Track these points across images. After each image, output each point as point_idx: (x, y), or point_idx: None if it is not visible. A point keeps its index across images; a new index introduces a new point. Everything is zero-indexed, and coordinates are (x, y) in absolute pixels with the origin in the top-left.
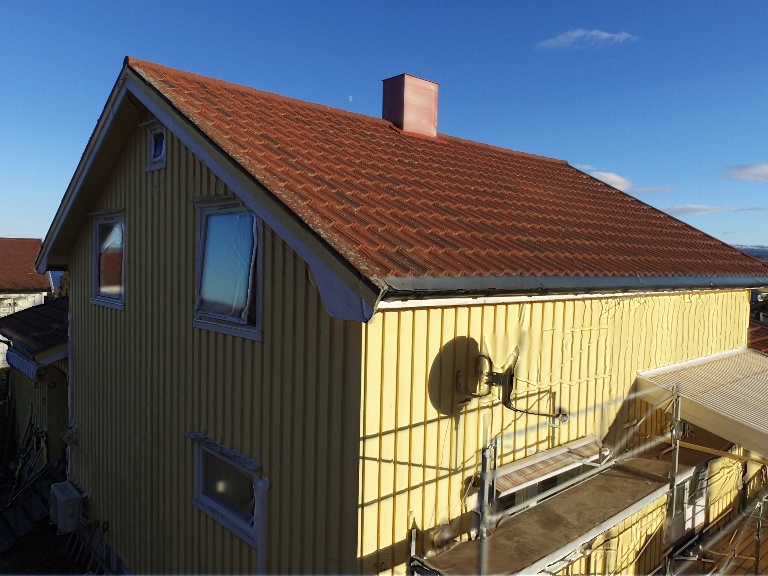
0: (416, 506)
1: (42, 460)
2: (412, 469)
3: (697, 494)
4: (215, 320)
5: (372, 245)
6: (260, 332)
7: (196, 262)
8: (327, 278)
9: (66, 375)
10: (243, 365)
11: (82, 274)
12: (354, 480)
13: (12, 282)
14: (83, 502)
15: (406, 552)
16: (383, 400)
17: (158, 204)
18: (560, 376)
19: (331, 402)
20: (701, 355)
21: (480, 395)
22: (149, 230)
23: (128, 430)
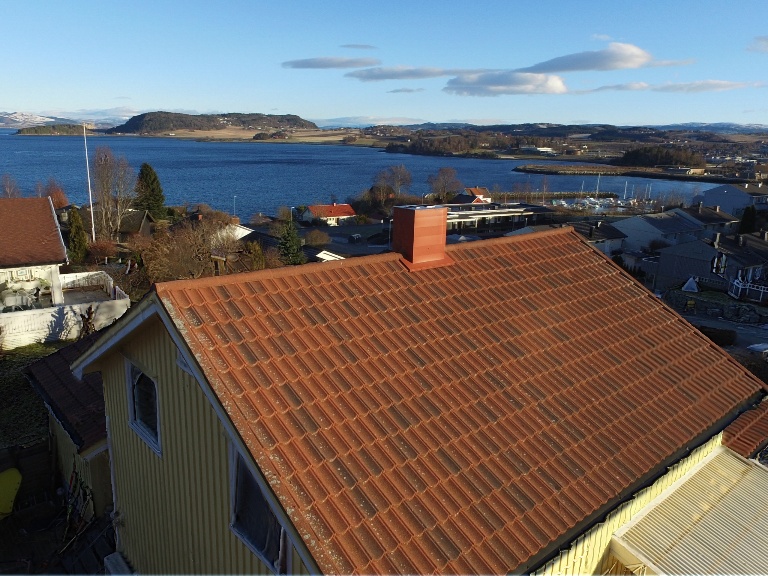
0: None
1: (90, 511)
2: None
3: None
4: None
5: None
6: None
7: (230, 481)
8: None
9: (108, 462)
10: None
11: (117, 392)
12: None
13: (28, 255)
14: None
15: None
16: None
17: (190, 401)
18: None
19: None
20: (675, 480)
21: None
22: (183, 415)
23: (172, 555)
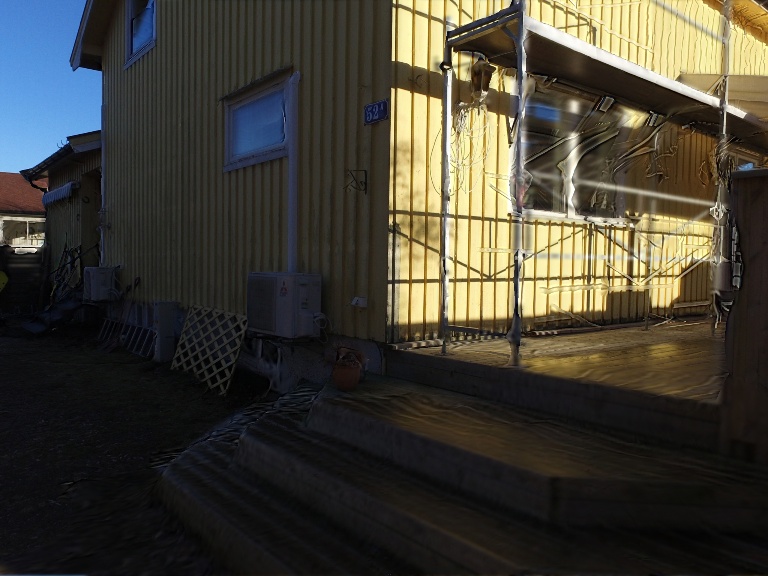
0: None
1: (76, 276)
2: (448, 2)
3: None
4: None
5: None
6: None
7: None
8: None
9: (99, 168)
10: None
11: (115, 52)
12: None
13: None
14: (115, 272)
15: (442, 89)
16: None
17: None
18: (600, 17)
19: None
20: None
21: None
22: None
23: (159, 163)
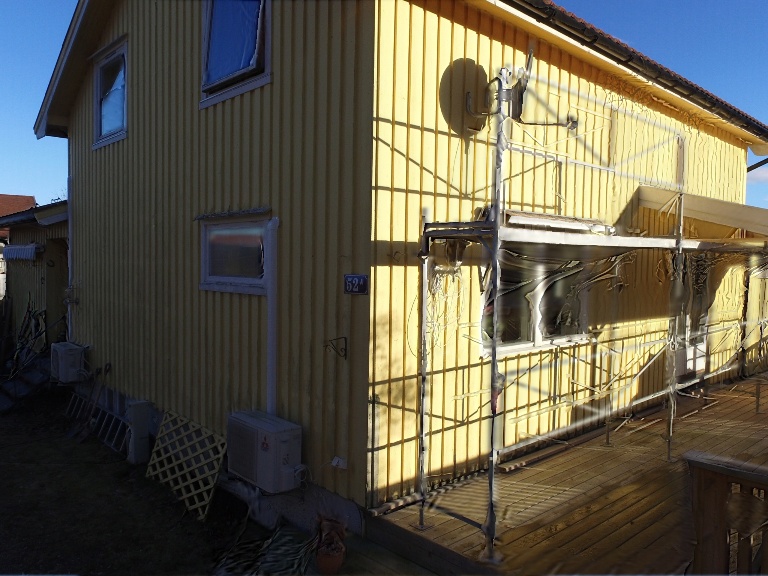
0: (428, 213)
1: (41, 340)
2: (424, 173)
3: (698, 339)
4: (222, 90)
5: None
6: (269, 73)
7: (202, 43)
8: None
9: (66, 239)
10: (251, 119)
11: (83, 127)
12: (367, 163)
13: None
14: (84, 353)
15: None
16: (396, 88)
17: (162, 9)
18: (566, 150)
19: (343, 101)
20: None
21: (490, 113)
22: (153, 40)
23: (131, 256)
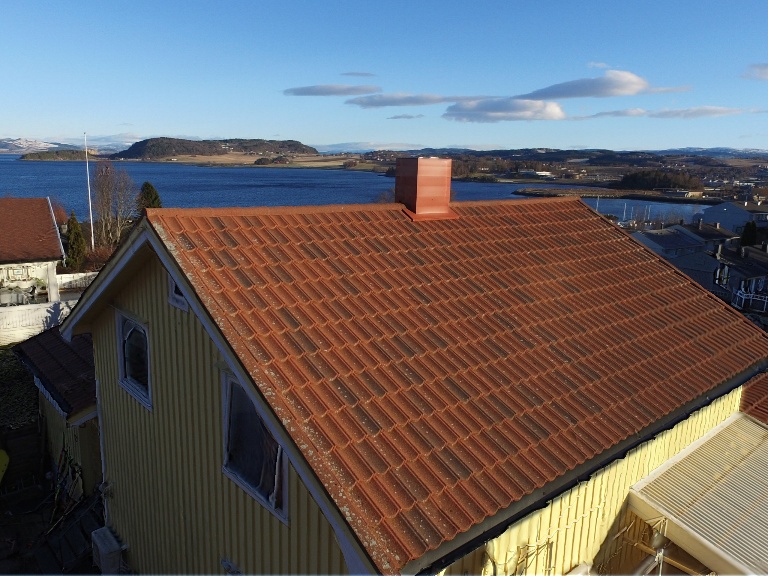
0: None
1: (78, 489)
2: None
3: None
4: None
5: (391, 511)
6: (287, 519)
7: (223, 418)
8: (352, 554)
9: (97, 431)
10: (271, 534)
11: (107, 351)
12: None
13: (24, 251)
14: (122, 554)
15: None
16: None
17: (182, 340)
18: (558, 525)
19: None
20: (693, 441)
21: None
22: (174, 357)
23: (162, 517)
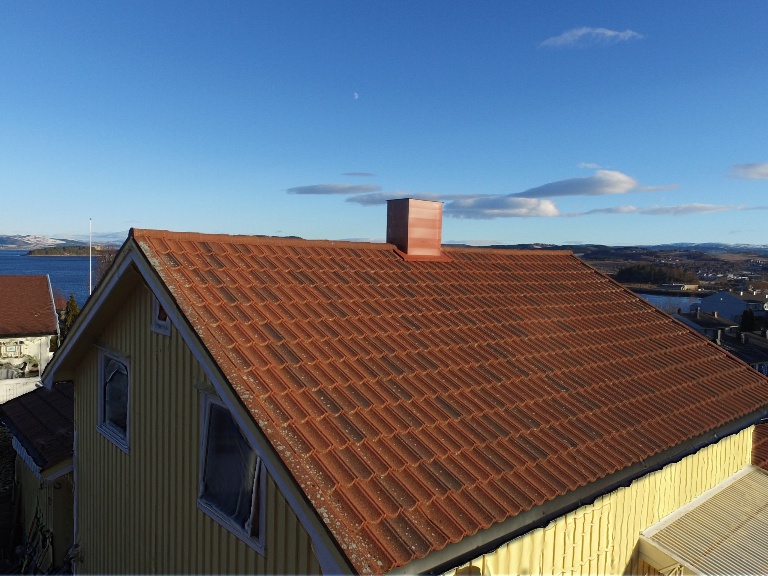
0: None
1: (48, 559)
2: None
3: None
4: None
5: (374, 516)
6: (263, 548)
7: (200, 445)
8: (329, 562)
9: None
10: (246, 570)
11: (87, 396)
12: None
13: (18, 326)
14: None
15: None
16: None
17: (163, 368)
18: (562, 566)
19: None
20: (705, 490)
21: None
22: (154, 388)
23: (133, 574)
